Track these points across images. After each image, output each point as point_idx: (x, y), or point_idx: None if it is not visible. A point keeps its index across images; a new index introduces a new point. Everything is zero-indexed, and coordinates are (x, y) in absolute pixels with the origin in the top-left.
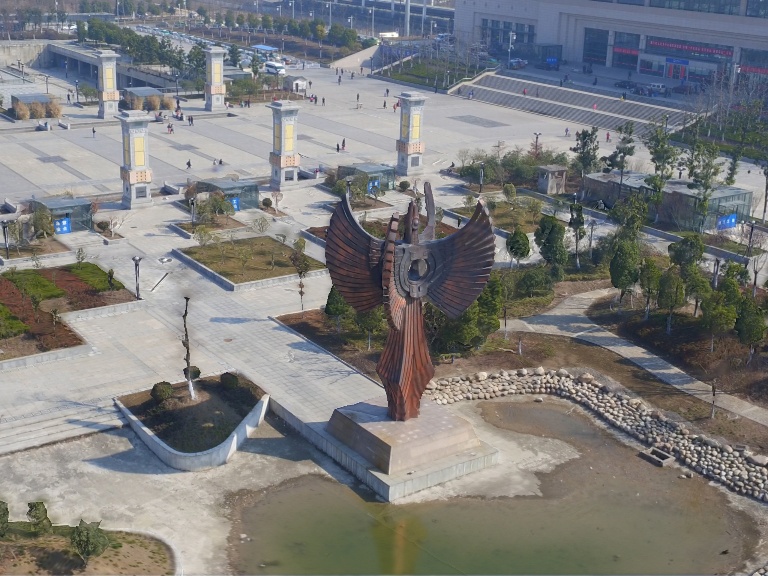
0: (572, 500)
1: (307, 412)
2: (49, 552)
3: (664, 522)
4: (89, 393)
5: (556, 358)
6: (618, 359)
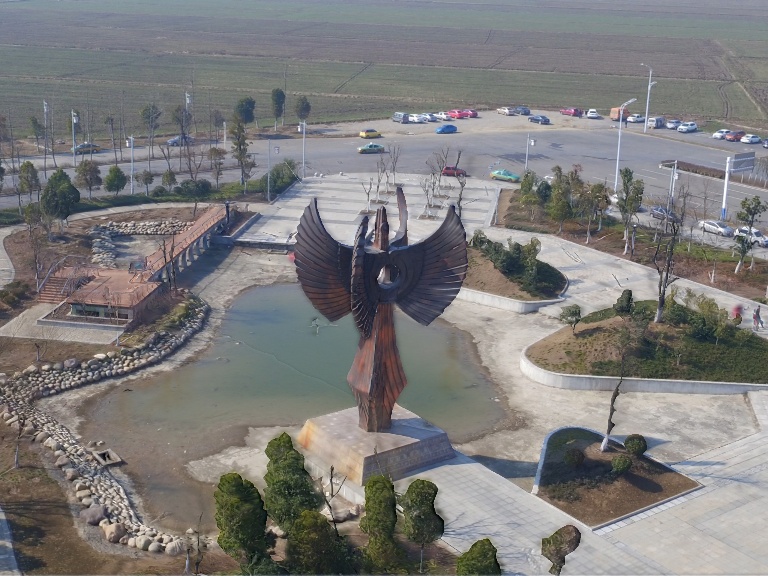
0: (225, 424)
1: (481, 474)
2: (600, 331)
3: (157, 409)
4: (739, 493)
5: (133, 571)
6: (35, 570)
